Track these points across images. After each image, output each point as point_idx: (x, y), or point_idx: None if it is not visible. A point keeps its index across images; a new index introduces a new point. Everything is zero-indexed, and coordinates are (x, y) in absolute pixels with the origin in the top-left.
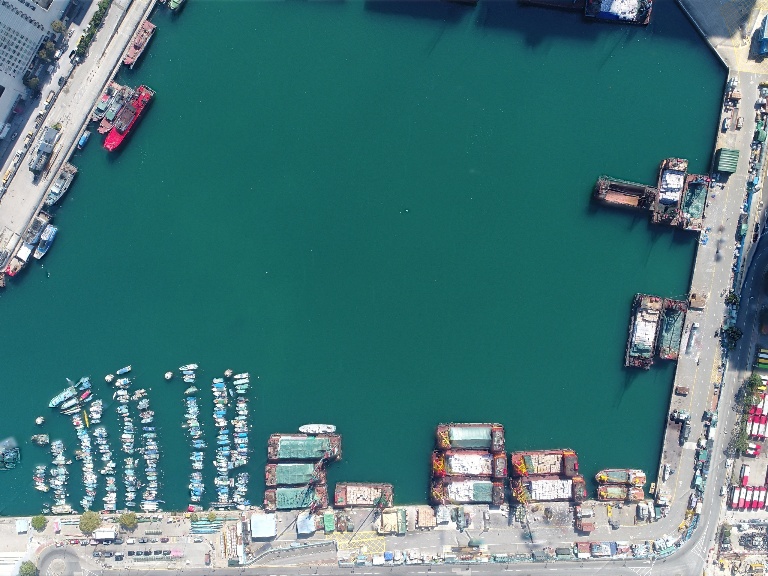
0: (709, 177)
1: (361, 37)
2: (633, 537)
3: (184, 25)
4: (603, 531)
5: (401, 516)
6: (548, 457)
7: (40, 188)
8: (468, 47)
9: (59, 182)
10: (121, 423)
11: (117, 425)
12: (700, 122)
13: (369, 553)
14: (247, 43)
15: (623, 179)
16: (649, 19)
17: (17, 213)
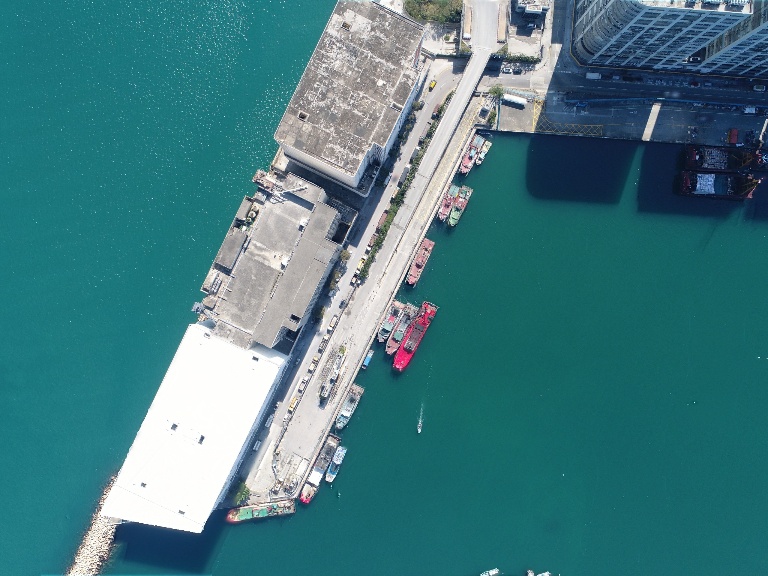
0: None
1: (637, 239)
2: None
3: (460, 238)
4: None
5: None
6: None
7: (327, 411)
8: (739, 241)
9: (350, 406)
10: None
11: None
12: None
13: None
14: (525, 252)
15: None
16: None
17: (304, 438)
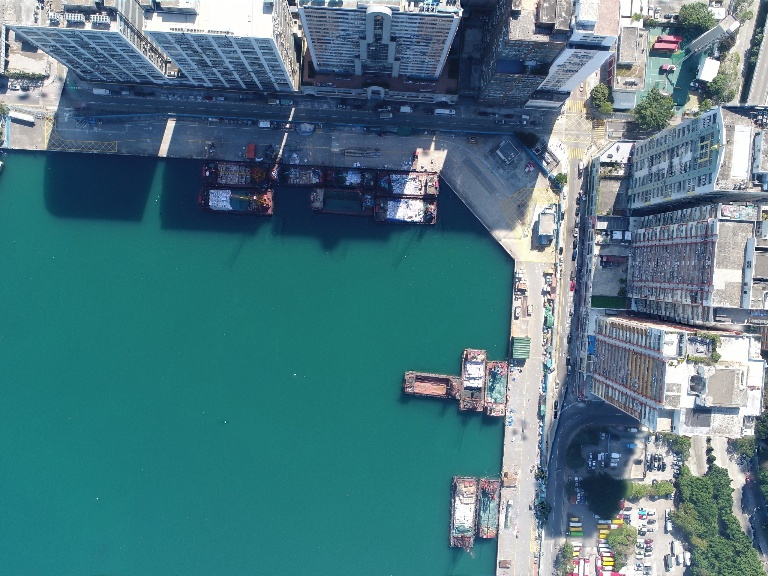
0: (508, 362)
1: (161, 256)
2: None
3: None
4: None
5: None
6: None
7: None
8: (268, 257)
9: None
10: None
11: None
12: (494, 310)
13: None
14: (46, 271)
15: (428, 372)
16: (436, 220)
17: None
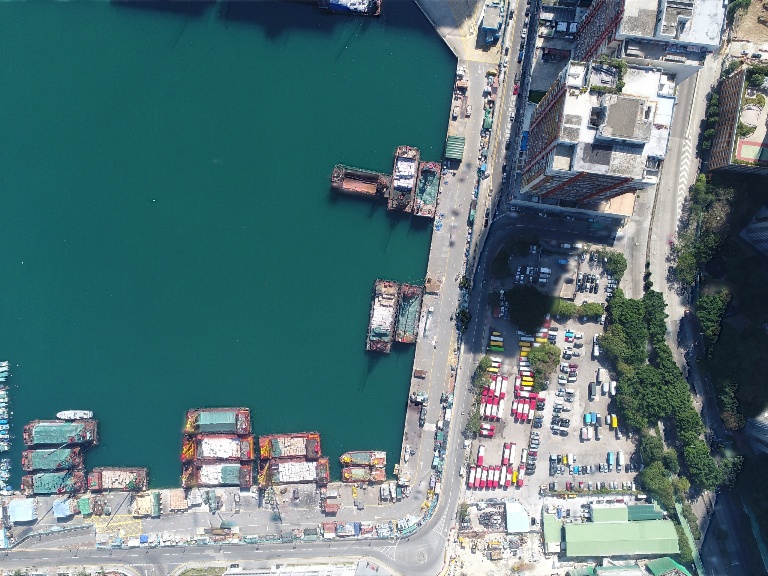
0: (441, 164)
1: (108, 31)
2: (378, 517)
3: None
4: (349, 512)
5: (153, 499)
6: (295, 440)
7: None
8: (211, 40)
9: None
10: None
11: None
12: (433, 110)
13: (126, 536)
14: None
15: (358, 167)
16: (380, 10)
17: None
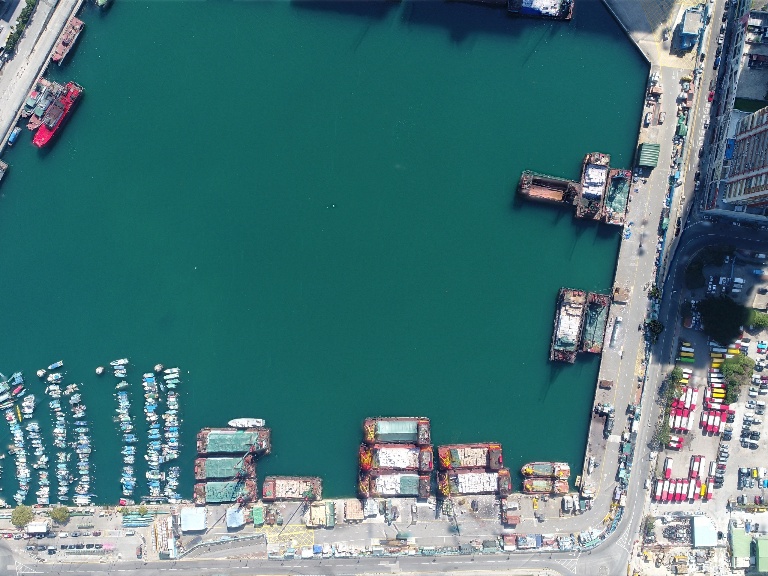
0: (632, 172)
1: (288, 33)
2: (559, 530)
3: (113, 22)
4: (529, 524)
5: (329, 509)
6: (474, 450)
7: None
8: (394, 43)
9: None
10: (53, 418)
11: (49, 420)
12: (623, 117)
13: (298, 546)
14: (175, 39)
15: (547, 174)
16: (571, 14)
17: None
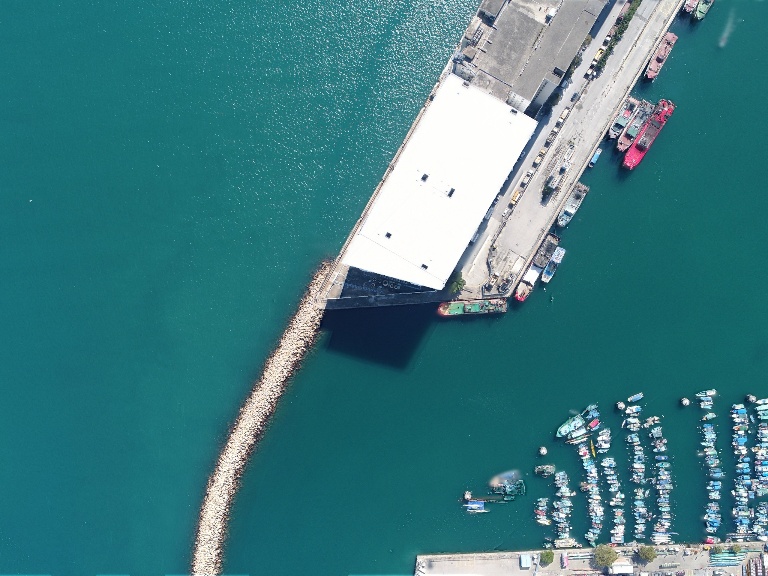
0: None
1: None
2: None
3: (703, 36)
4: None
5: None
6: None
7: (548, 209)
8: None
9: (575, 202)
10: (630, 452)
11: (626, 454)
12: None
13: None
14: None
15: None
16: None
17: (523, 235)
